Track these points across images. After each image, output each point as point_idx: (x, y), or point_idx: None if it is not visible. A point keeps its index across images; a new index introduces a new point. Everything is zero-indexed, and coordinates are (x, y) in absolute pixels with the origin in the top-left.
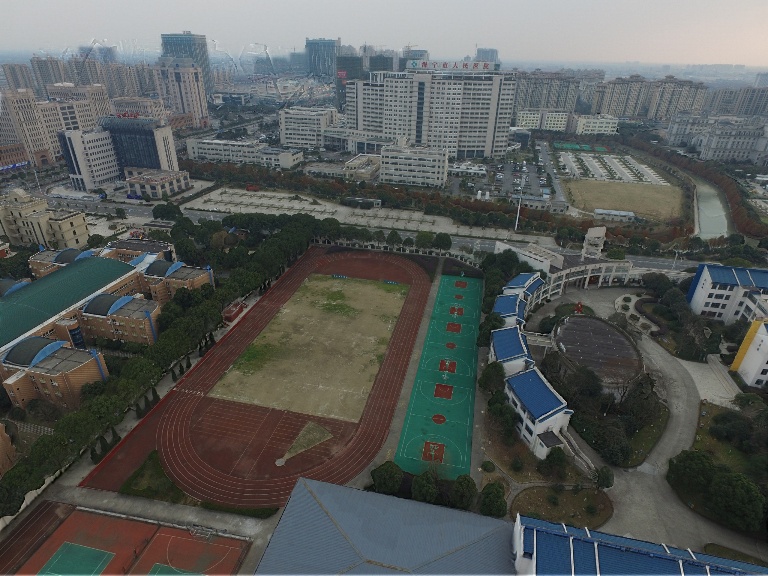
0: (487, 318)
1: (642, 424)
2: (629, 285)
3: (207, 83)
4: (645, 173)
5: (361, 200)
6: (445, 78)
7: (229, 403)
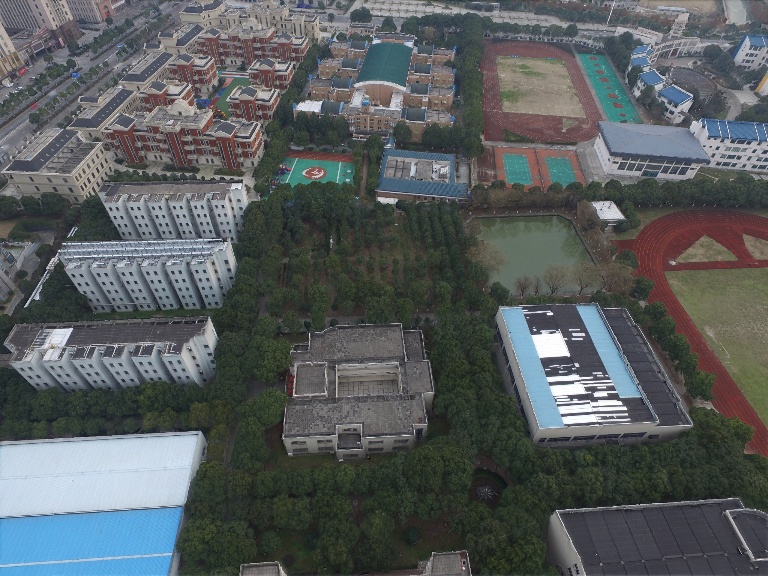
0: (633, 68)
1: (720, 109)
2: (694, 55)
3: None
4: None
5: (484, 4)
6: None
7: (518, 113)
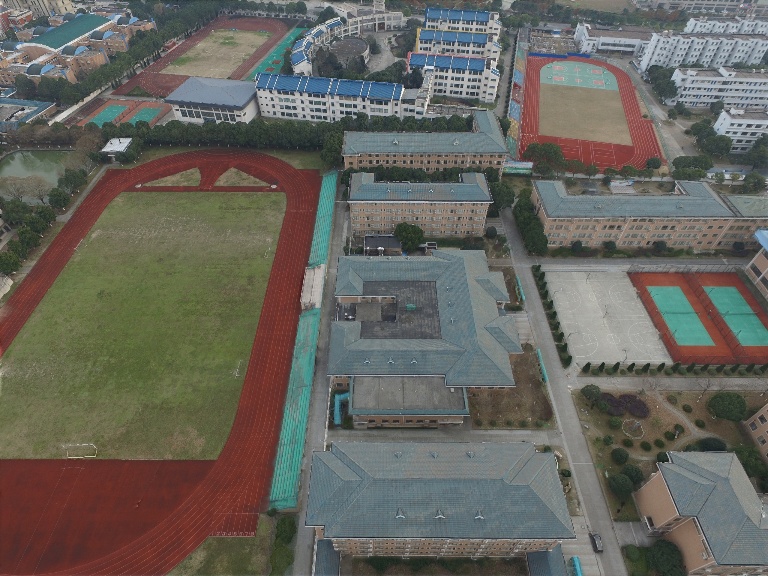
0: None
1: None
2: (403, 29)
3: None
4: None
5: None
6: None
7: (169, 75)
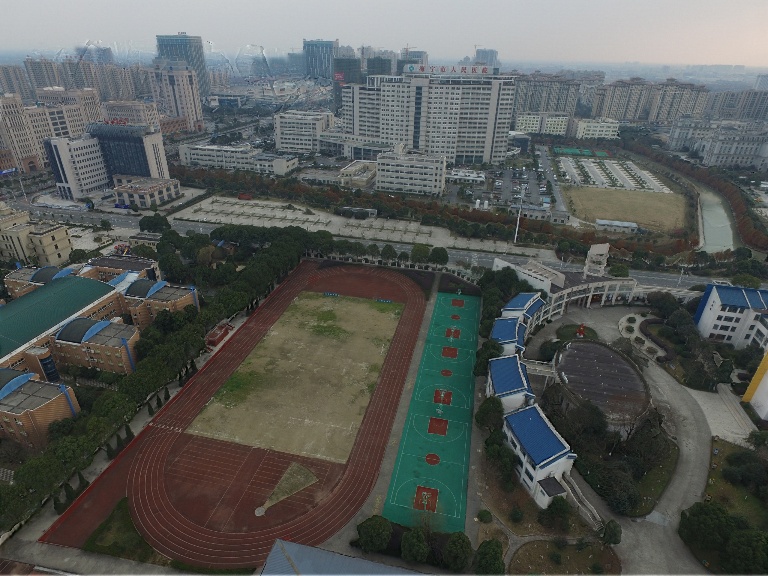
0: (485, 345)
1: (651, 467)
2: (633, 304)
3: (203, 85)
4: (647, 180)
5: (356, 210)
6: (443, 82)
7: (208, 441)
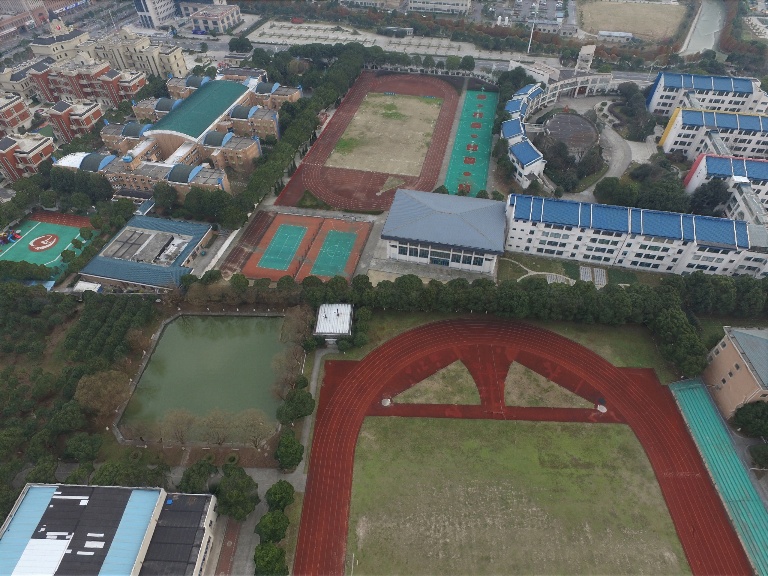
0: (500, 115)
1: (588, 171)
2: (609, 94)
3: None
4: None
5: (396, 29)
6: None
7: (339, 169)
